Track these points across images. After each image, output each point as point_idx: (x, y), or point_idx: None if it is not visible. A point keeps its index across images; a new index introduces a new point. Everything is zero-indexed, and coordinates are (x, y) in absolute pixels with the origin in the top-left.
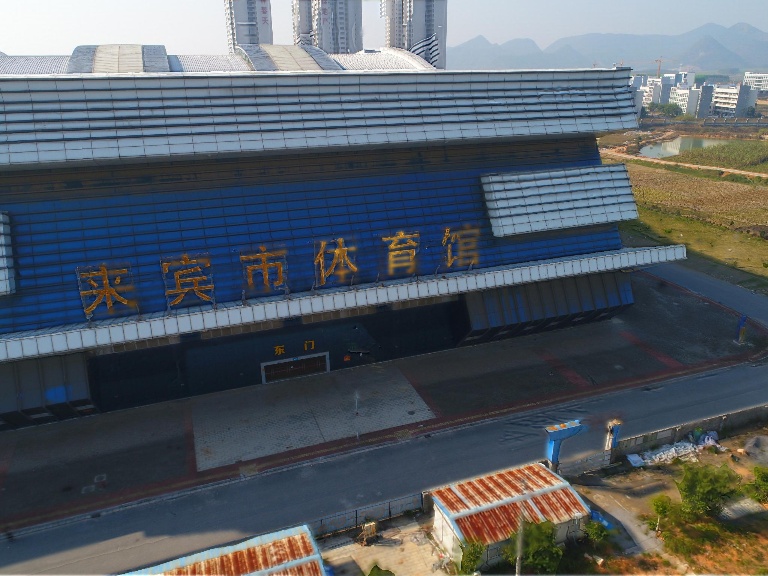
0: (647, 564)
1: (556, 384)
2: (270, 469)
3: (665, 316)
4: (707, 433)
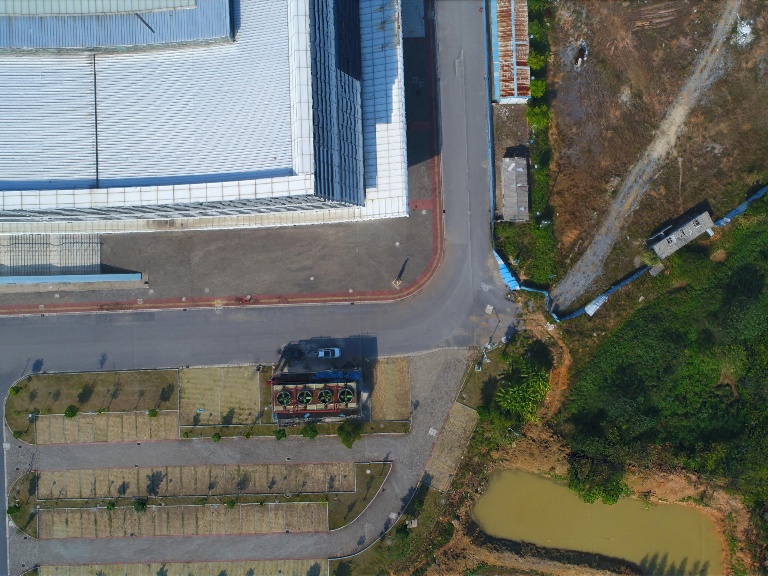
0: None
1: None
2: (434, 5)
3: None
4: None
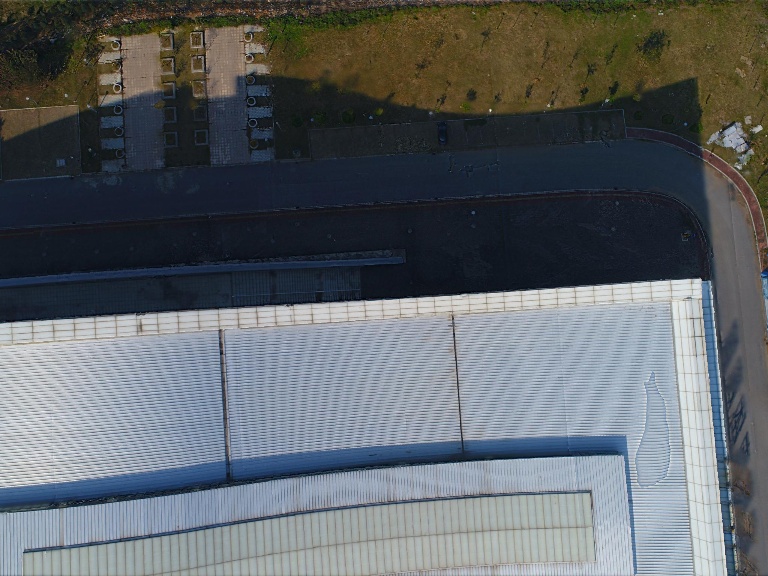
0: None
1: None
2: None
3: (637, 258)
4: None
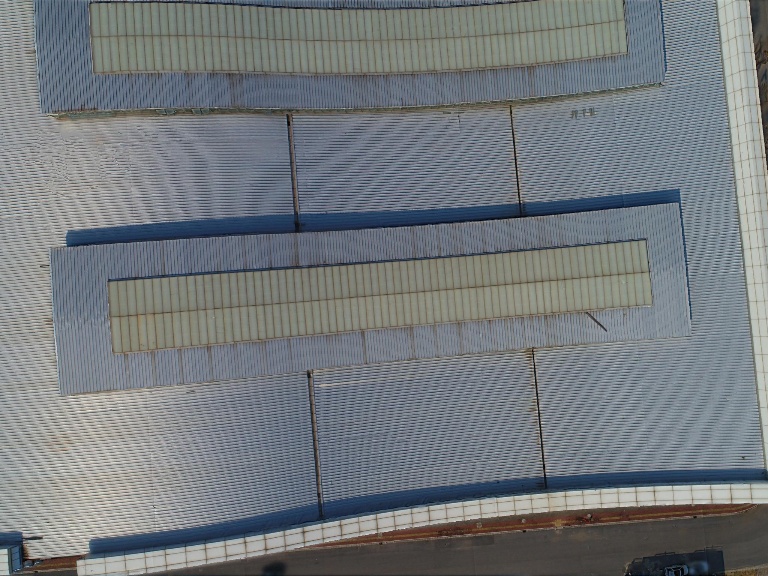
0: None
1: None
2: None
3: None
4: None
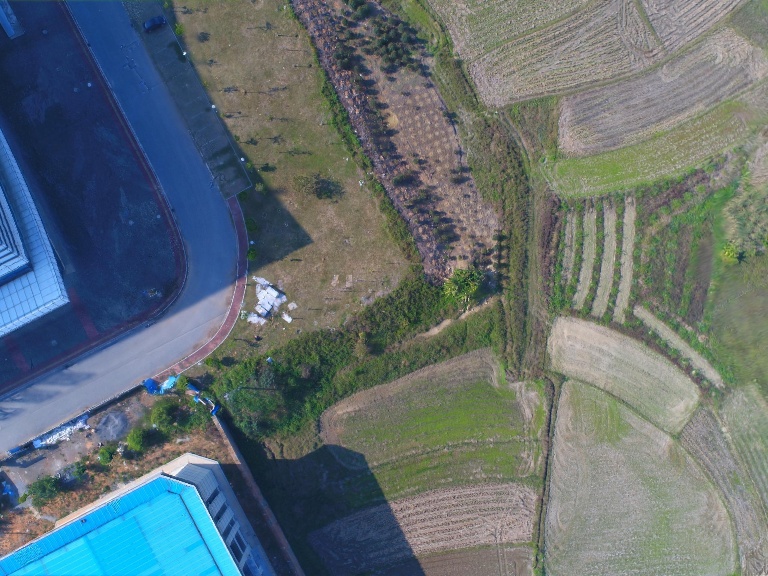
0: (22, 514)
1: (7, 373)
2: None
3: (111, 255)
4: (81, 417)
